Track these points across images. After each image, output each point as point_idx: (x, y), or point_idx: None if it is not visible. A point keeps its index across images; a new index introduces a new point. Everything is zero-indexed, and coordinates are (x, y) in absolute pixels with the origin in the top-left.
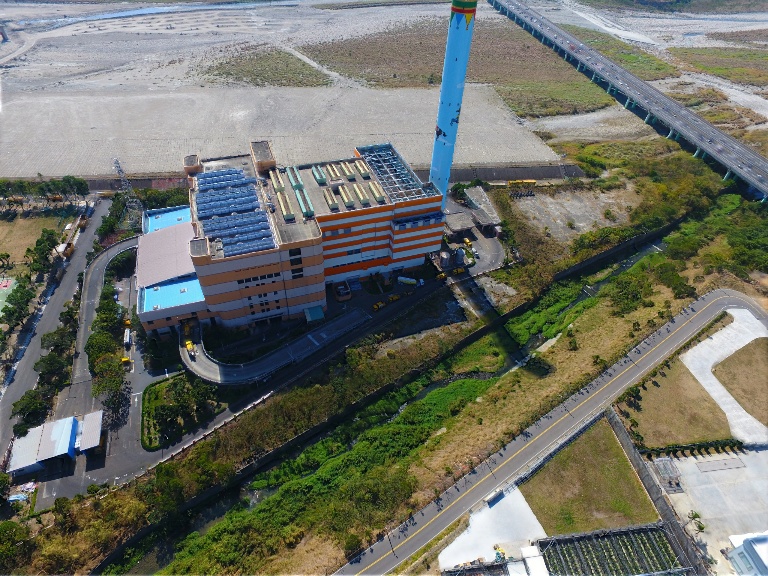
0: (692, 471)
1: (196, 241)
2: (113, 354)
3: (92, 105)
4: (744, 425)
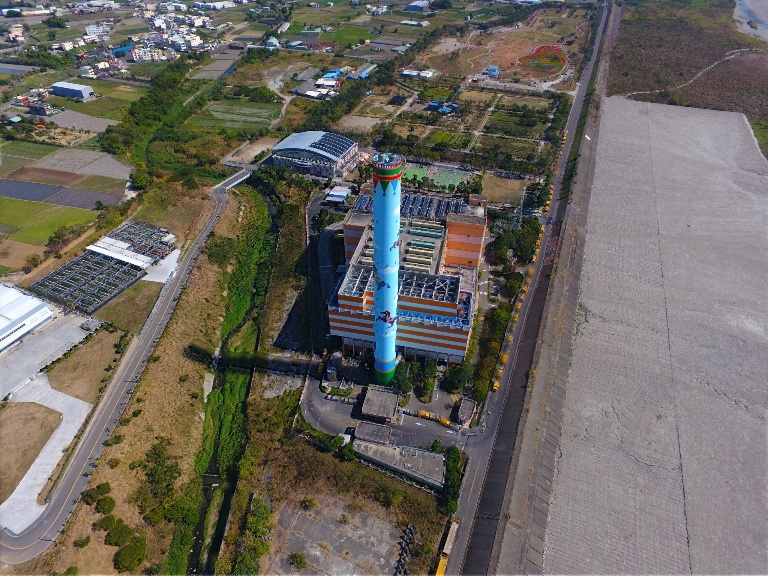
0: (75, 338)
1: None
2: None
3: (754, 229)
4: (37, 390)
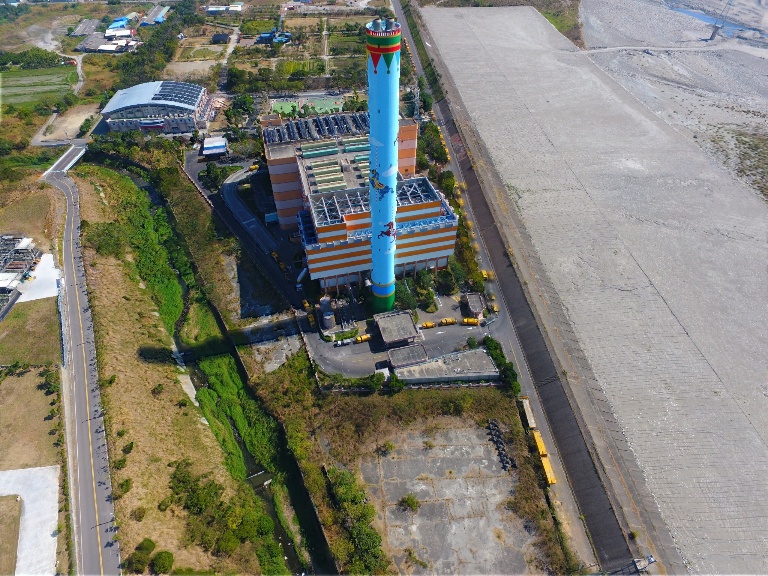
0: None
1: (278, 116)
2: (262, 147)
3: (592, 93)
4: None
